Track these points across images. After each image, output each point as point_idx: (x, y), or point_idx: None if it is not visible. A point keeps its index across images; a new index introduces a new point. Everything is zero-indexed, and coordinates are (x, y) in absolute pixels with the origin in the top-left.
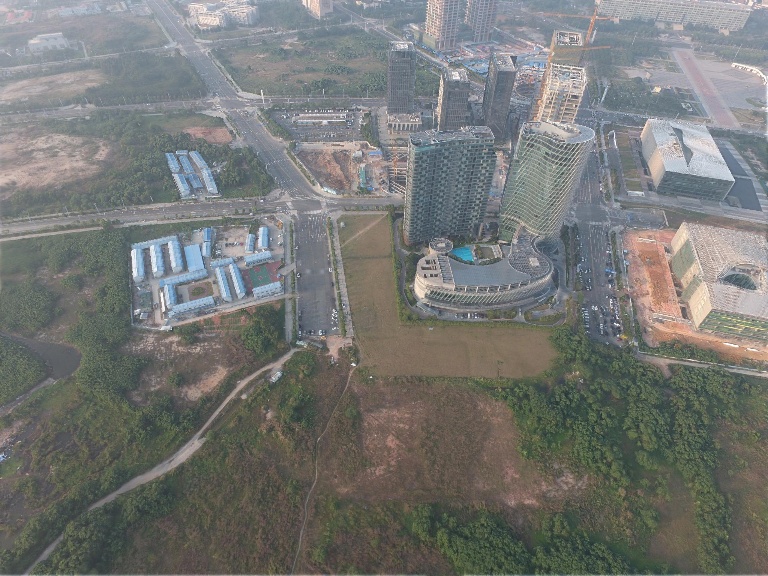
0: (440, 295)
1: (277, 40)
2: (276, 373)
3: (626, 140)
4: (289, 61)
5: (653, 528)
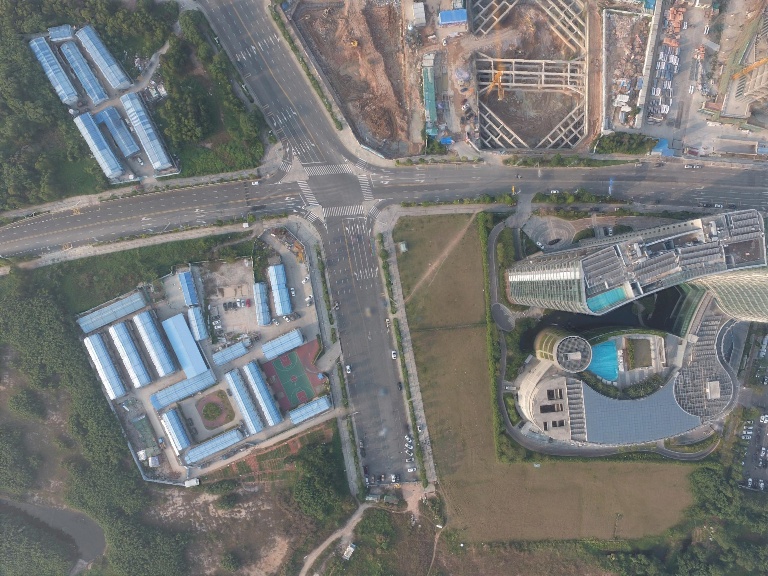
0: None
1: None
2: (348, 550)
3: None
4: None
5: None
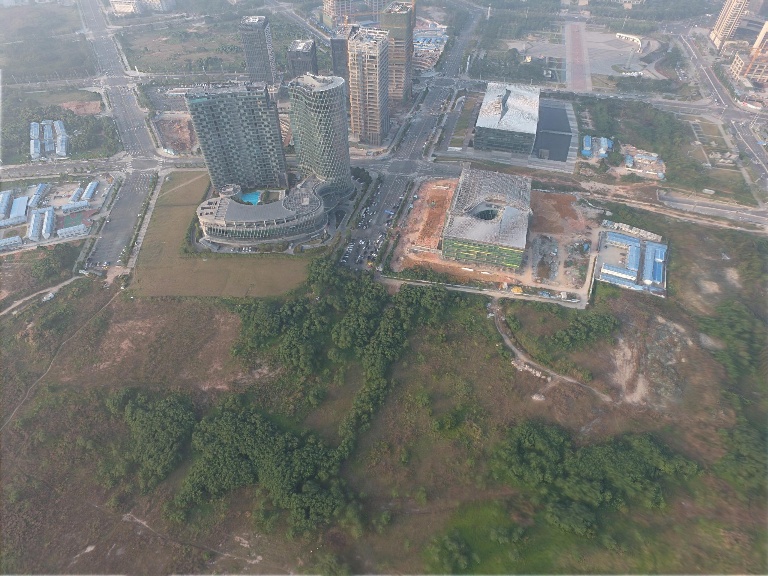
0: (215, 231)
1: (184, 24)
2: (48, 294)
3: (472, 104)
4: (188, 43)
5: (315, 405)
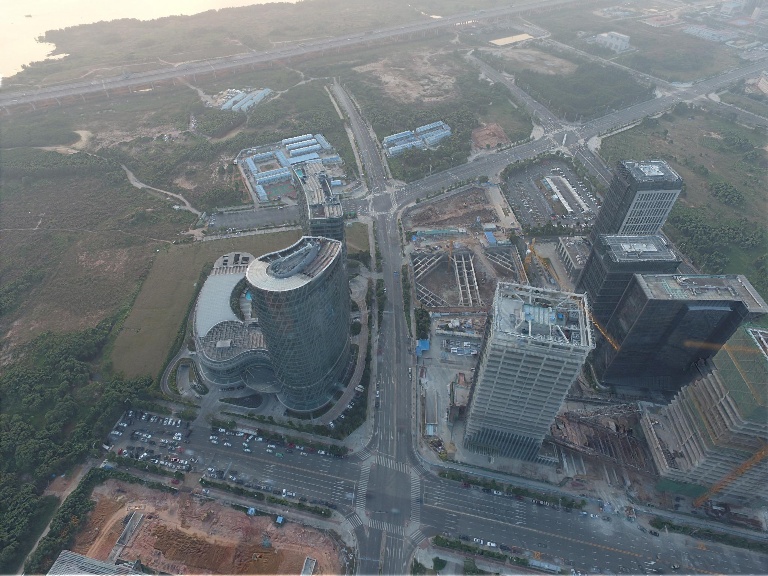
0: None
1: None
2: None
3: None
4: (722, 156)
5: None
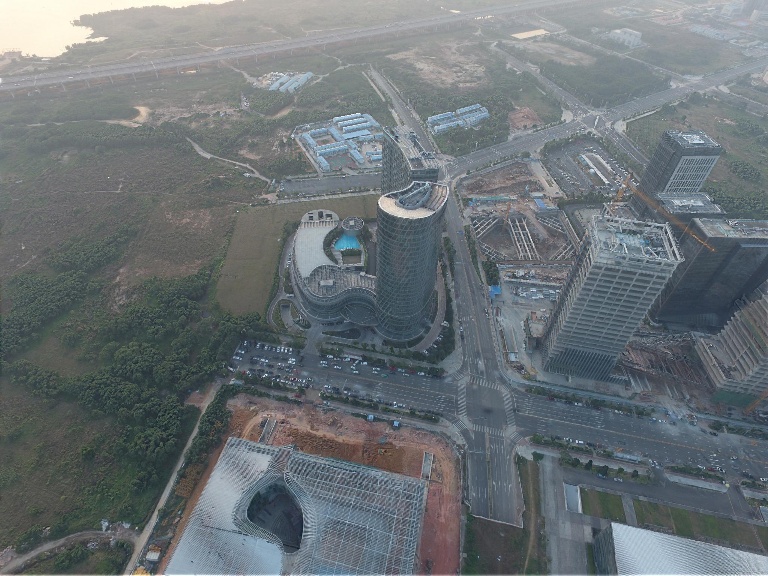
0: None
1: None
2: (249, 174)
3: None
4: (737, 139)
5: None
